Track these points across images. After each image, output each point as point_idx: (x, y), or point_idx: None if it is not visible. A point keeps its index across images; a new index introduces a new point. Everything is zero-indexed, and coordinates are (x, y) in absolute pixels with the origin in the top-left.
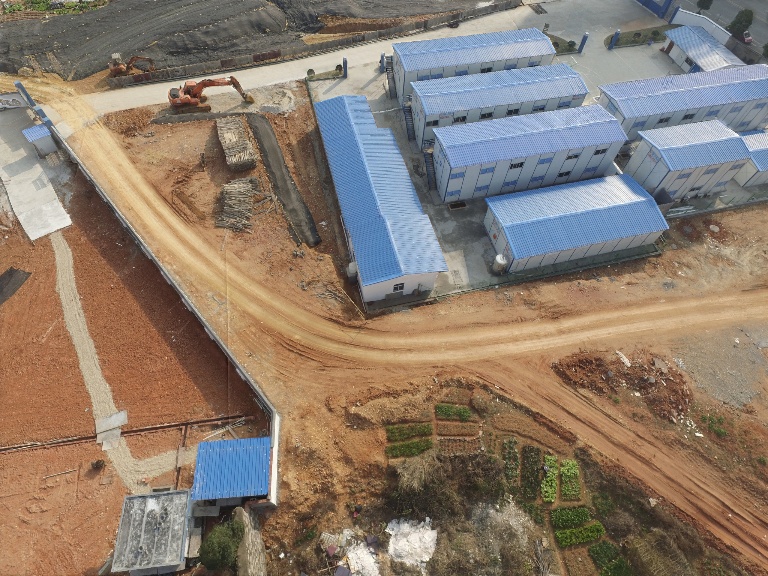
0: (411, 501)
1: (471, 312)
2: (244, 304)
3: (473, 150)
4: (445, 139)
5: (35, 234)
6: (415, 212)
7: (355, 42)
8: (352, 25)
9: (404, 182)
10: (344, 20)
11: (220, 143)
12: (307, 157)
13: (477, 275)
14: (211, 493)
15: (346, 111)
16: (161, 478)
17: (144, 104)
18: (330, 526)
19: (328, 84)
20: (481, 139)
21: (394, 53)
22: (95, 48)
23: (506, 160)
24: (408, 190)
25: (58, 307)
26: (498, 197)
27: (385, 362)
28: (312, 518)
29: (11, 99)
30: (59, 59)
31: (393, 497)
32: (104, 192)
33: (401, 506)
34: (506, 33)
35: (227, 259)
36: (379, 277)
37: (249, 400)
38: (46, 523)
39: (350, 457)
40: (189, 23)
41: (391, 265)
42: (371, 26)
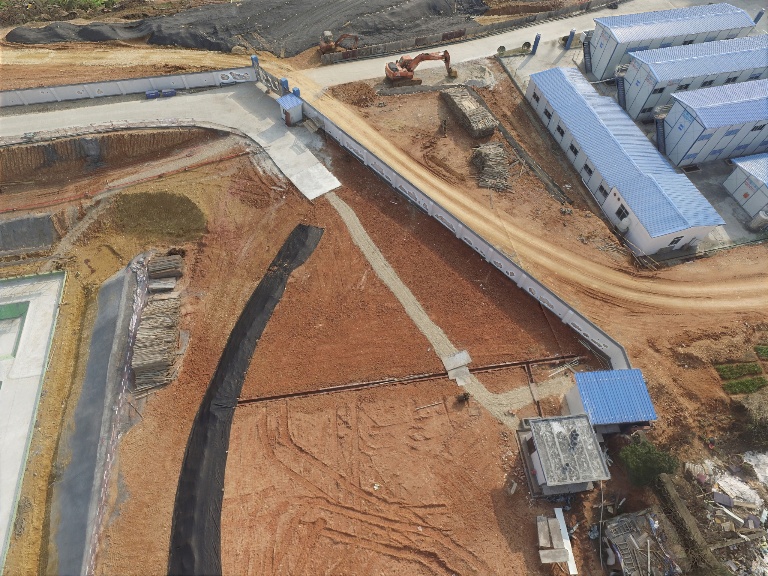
0: (767, 433)
1: (751, 264)
2: (533, 256)
3: (722, 112)
4: (690, 102)
5: (311, 194)
6: (669, 172)
7: (527, 22)
8: (515, 7)
9: (647, 145)
10: (507, 3)
11: (451, 112)
12: (527, 126)
13: (735, 232)
14: (605, 418)
15: (567, 81)
16: (524, 410)
17: (359, 78)
18: (690, 457)
19: (519, 60)
20: (726, 102)
21: (597, 27)
22: (294, 28)
23: (755, 121)
24: (654, 152)
25: (363, 258)
26: (744, 158)
27: (689, 308)
28: (669, 450)
29: (243, 73)
30: (265, 38)
31: (749, 429)
32: (374, 154)
33: (757, 438)
34: (699, 8)
35: (501, 216)
36: (666, 229)
37: (576, 342)
38: (434, 449)
39: (694, 393)
40: (373, 5)
41: (674, 218)
42: (532, 8)
